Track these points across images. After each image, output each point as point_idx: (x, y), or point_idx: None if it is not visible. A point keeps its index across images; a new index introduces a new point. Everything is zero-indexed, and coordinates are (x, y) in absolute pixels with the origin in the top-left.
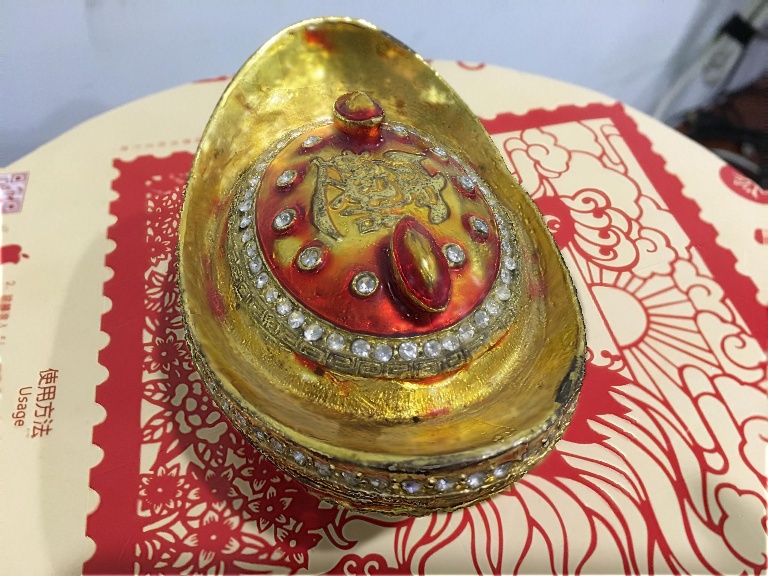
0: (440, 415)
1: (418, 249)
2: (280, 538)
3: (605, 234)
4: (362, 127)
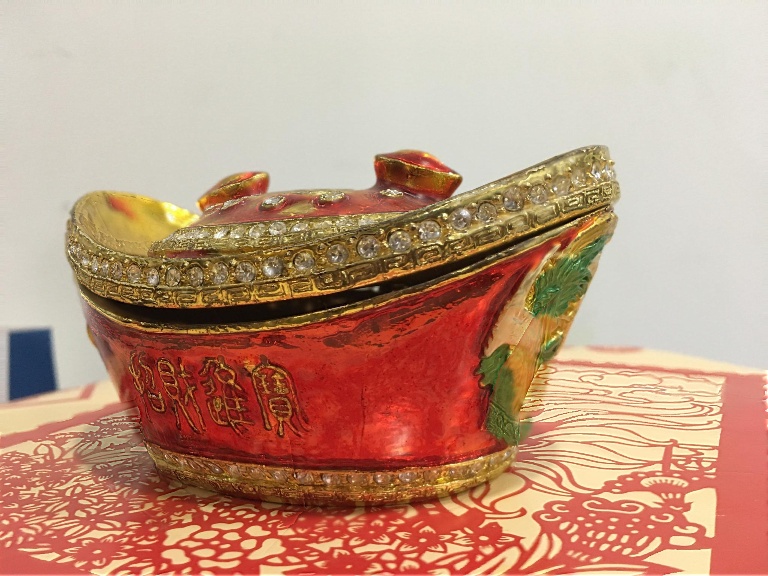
0: None
1: (415, 151)
2: (468, 543)
3: None
4: (258, 180)
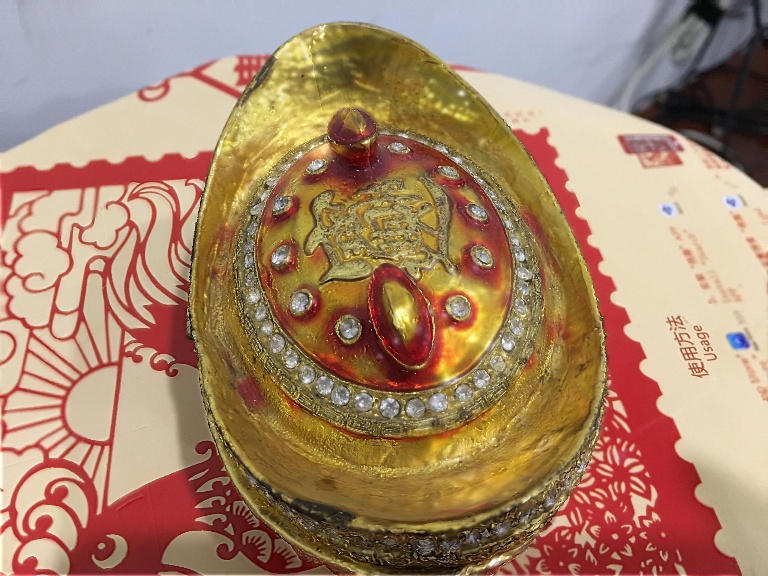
0: None
1: None
2: None
3: (42, 524)
4: None
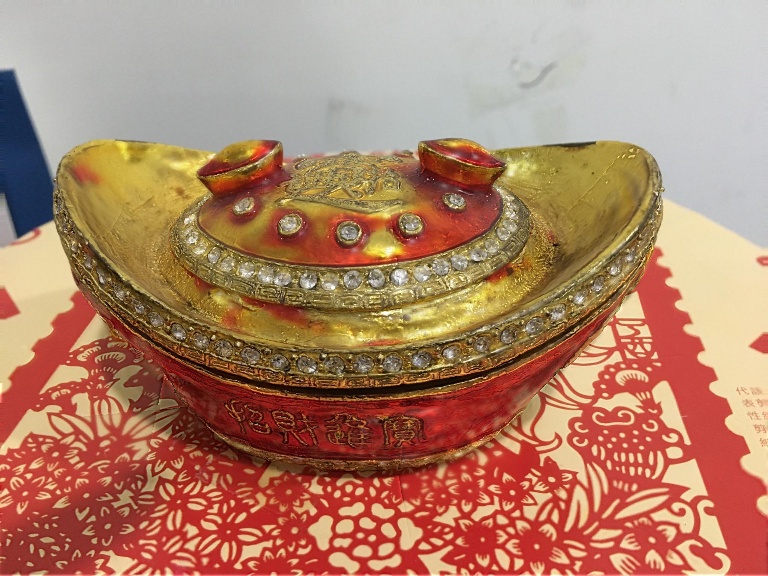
0: (554, 234)
1: (463, 141)
2: (545, 489)
3: None
4: (275, 156)
